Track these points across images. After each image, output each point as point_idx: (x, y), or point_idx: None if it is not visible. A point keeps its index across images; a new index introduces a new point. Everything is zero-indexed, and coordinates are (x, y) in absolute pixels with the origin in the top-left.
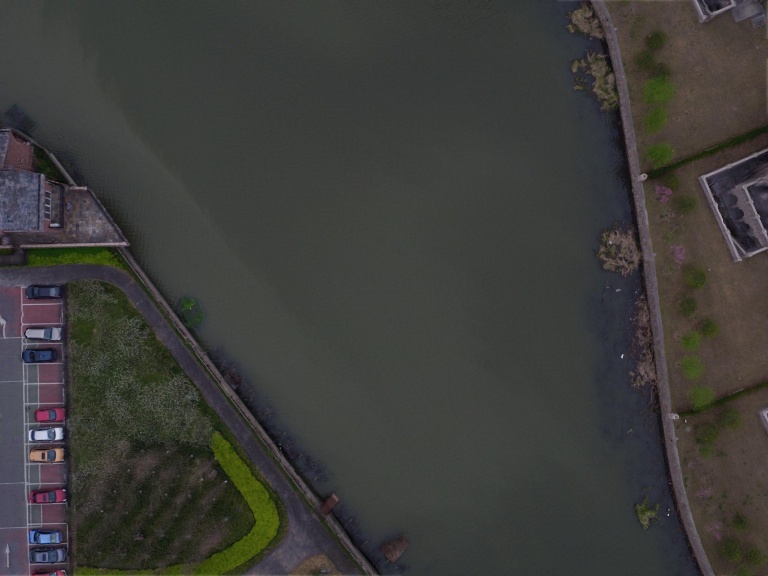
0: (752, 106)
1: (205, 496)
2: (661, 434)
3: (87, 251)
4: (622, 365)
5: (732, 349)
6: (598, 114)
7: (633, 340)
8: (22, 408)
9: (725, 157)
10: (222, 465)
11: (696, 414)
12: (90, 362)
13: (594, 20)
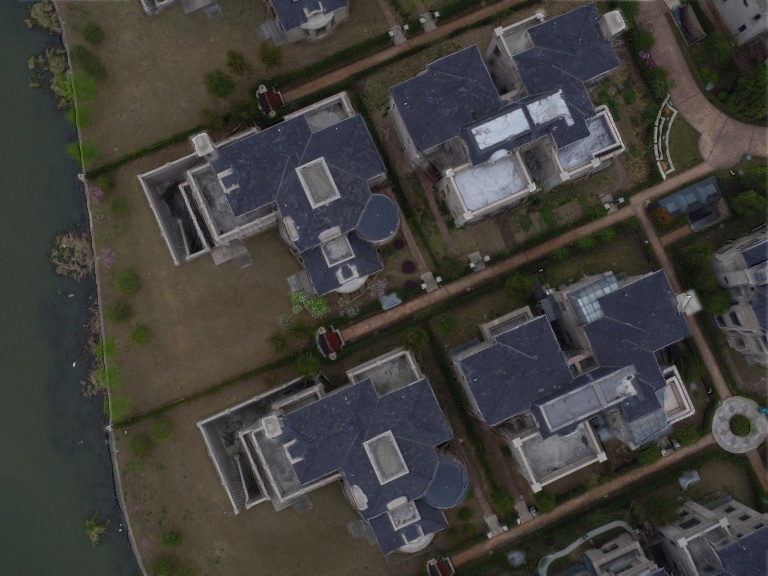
0: (200, 101)
1: None
2: (107, 446)
3: None
4: (73, 374)
5: (172, 357)
6: (55, 112)
7: (86, 347)
8: None
9: (170, 155)
10: None
11: (133, 425)
12: None
13: (53, 14)
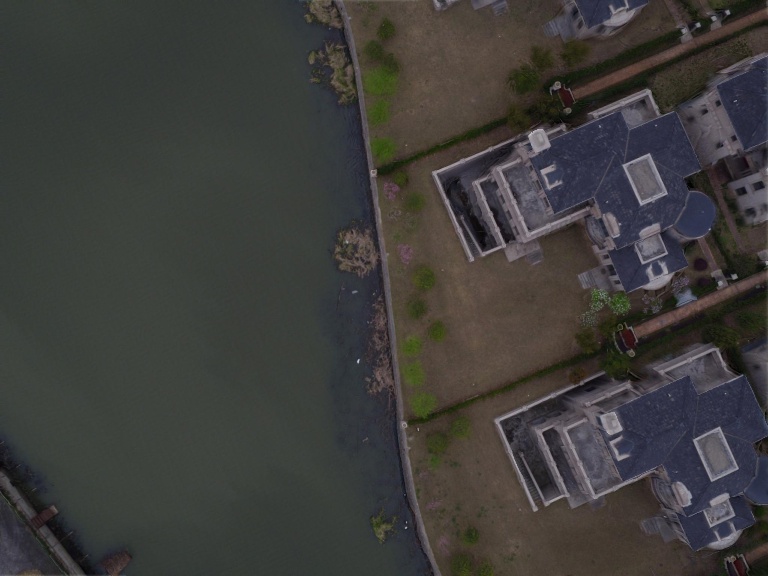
0: (491, 98)
1: None
2: (396, 443)
3: None
4: (358, 370)
5: (466, 353)
6: (336, 107)
7: (370, 344)
8: None
9: (461, 151)
10: None
11: (427, 422)
12: None
13: (333, 9)
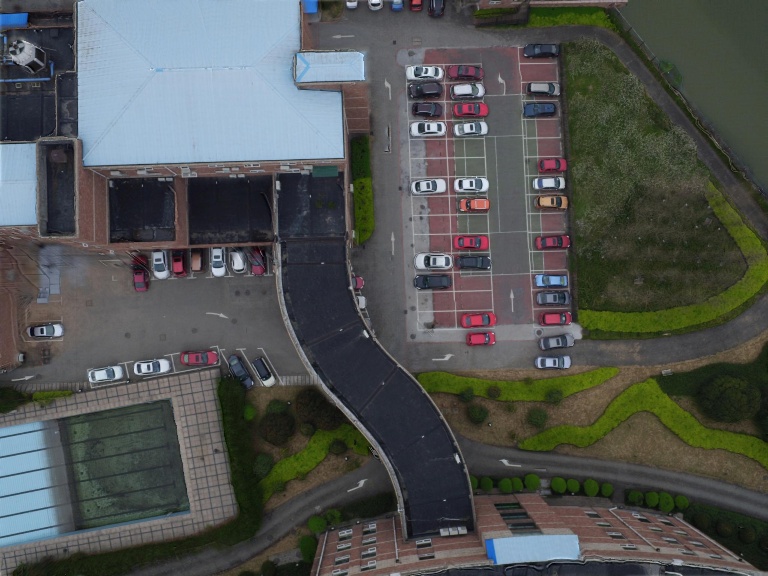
0: None
1: (700, 243)
2: None
3: (585, 11)
4: None
5: None
6: None
7: None
8: (522, 160)
9: None
10: (716, 212)
11: None
12: (596, 112)
13: None
